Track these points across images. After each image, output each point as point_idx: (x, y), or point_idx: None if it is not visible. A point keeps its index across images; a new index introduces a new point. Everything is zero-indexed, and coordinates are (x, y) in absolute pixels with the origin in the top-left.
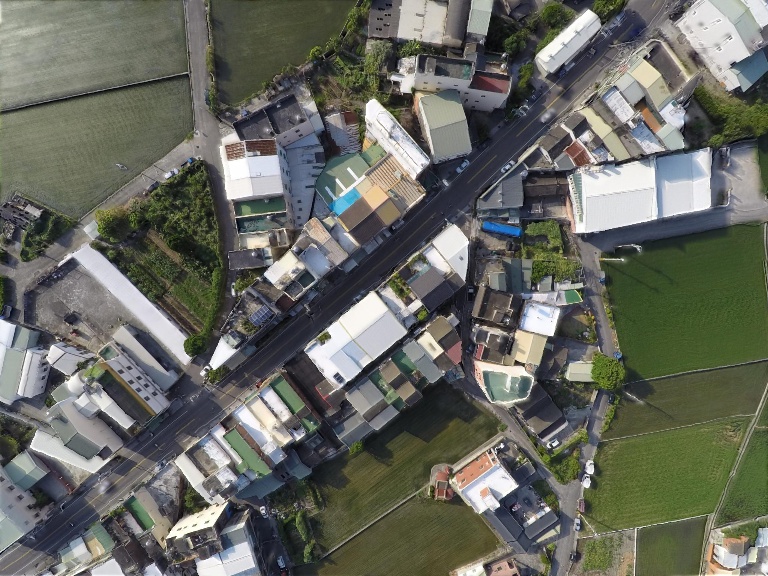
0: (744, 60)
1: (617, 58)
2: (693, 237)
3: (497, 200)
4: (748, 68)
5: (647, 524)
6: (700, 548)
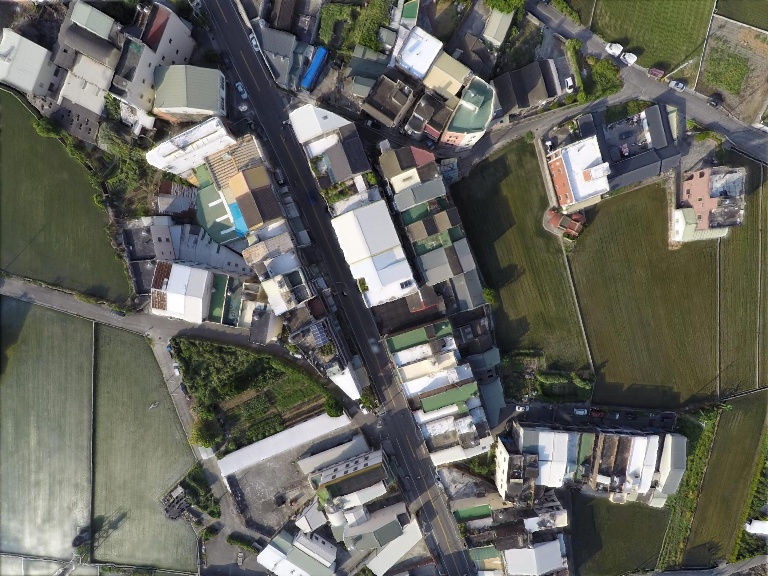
0: None
1: None
2: None
3: (281, 62)
4: None
5: None
6: None
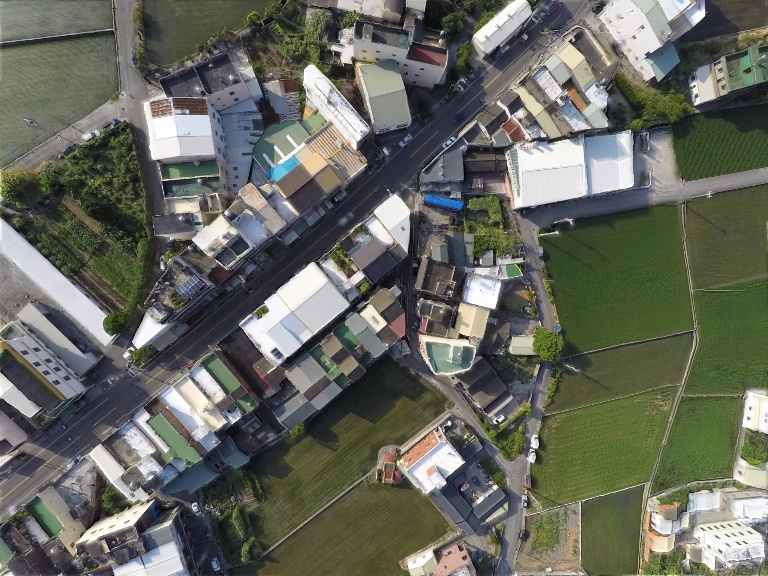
0: (656, 51)
1: (547, 44)
2: (621, 216)
3: (438, 173)
4: (660, 59)
5: (590, 496)
6: (639, 518)
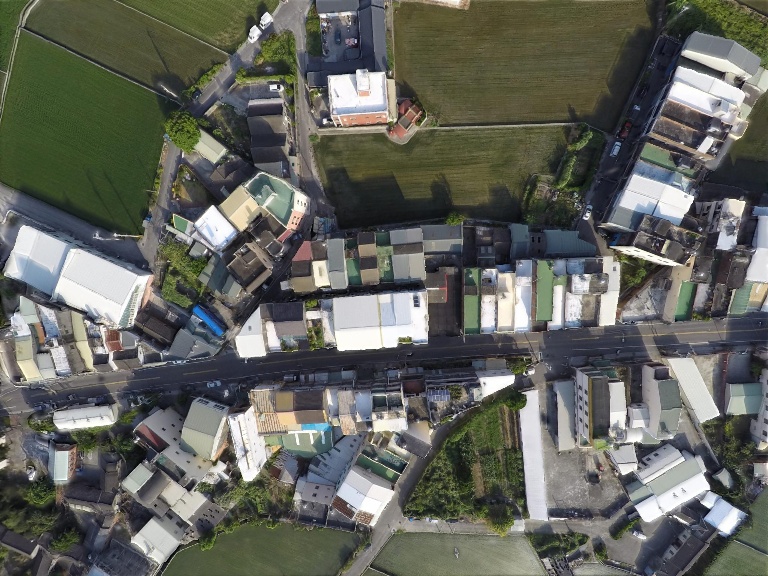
0: None
1: None
2: (52, 201)
3: (198, 348)
4: None
5: None
6: None
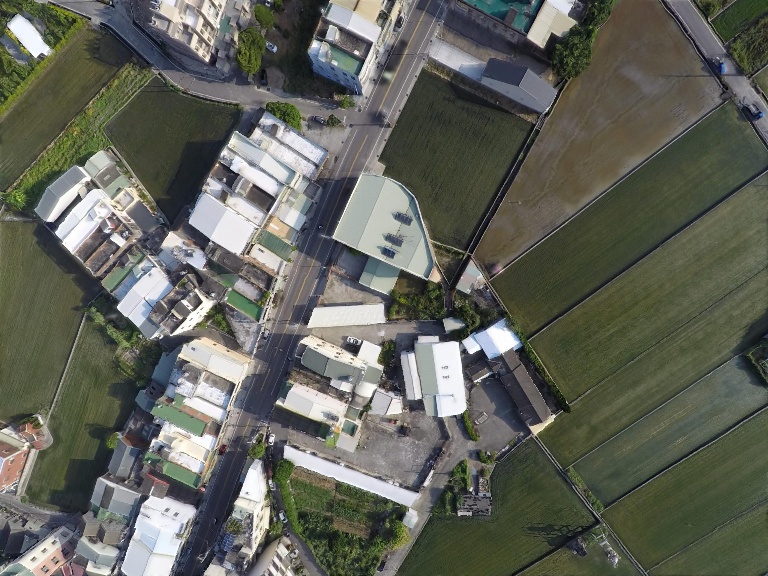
0: None
1: None
2: None
3: None
4: None
5: None
6: None
